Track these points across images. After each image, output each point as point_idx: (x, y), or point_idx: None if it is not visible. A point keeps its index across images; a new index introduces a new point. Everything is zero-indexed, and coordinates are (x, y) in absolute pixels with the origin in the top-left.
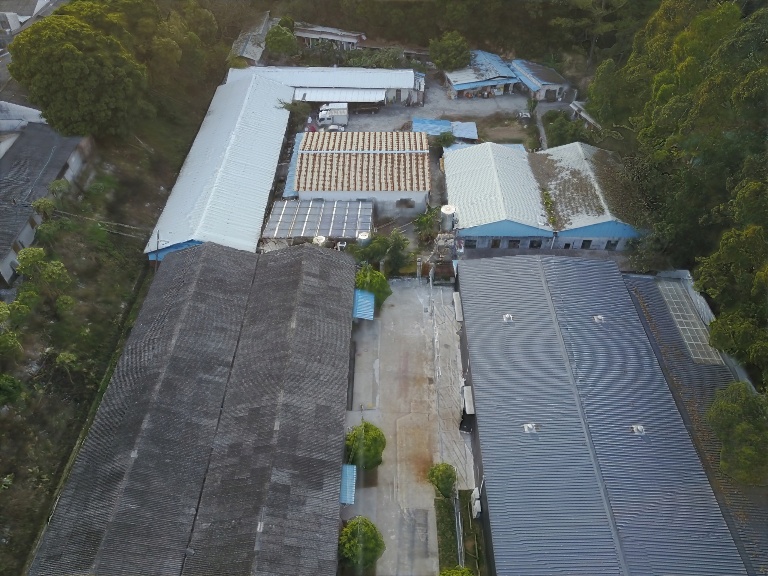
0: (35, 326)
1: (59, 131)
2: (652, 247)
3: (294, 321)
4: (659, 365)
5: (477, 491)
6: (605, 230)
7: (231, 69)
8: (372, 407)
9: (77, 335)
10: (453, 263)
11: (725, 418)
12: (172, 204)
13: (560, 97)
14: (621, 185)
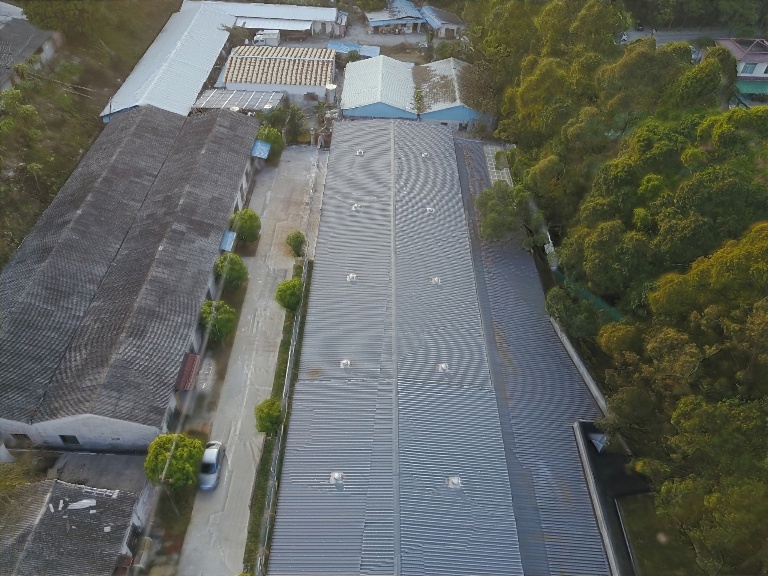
0: (12, 149)
1: (36, 24)
2: (481, 119)
3: (204, 150)
4: (459, 181)
5: None
6: (456, 114)
7: (185, 1)
8: (260, 216)
9: (44, 160)
10: None
11: (484, 198)
12: (125, 87)
13: (458, 36)
14: (477, 87)
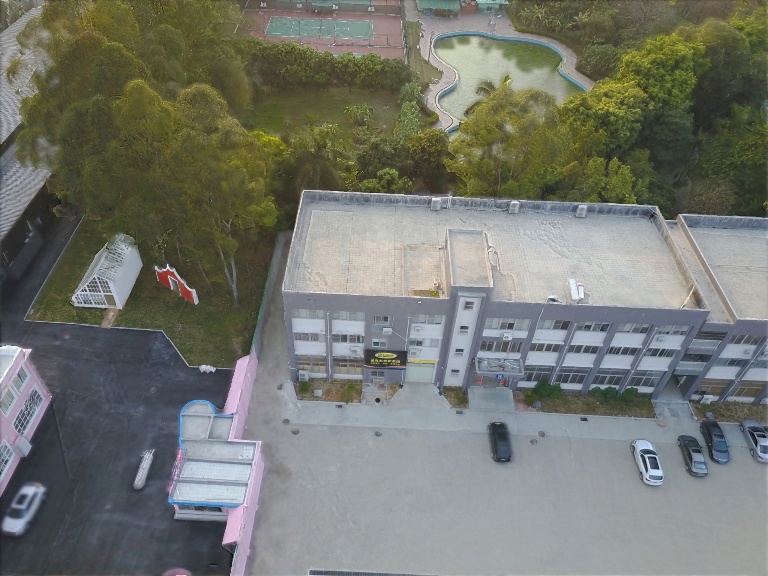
0: None
1: None
2: None
3: None
4: None
5: None
6: None
7: None
8: None
9: None
10: None
11: None
12: None
13: None
14: None
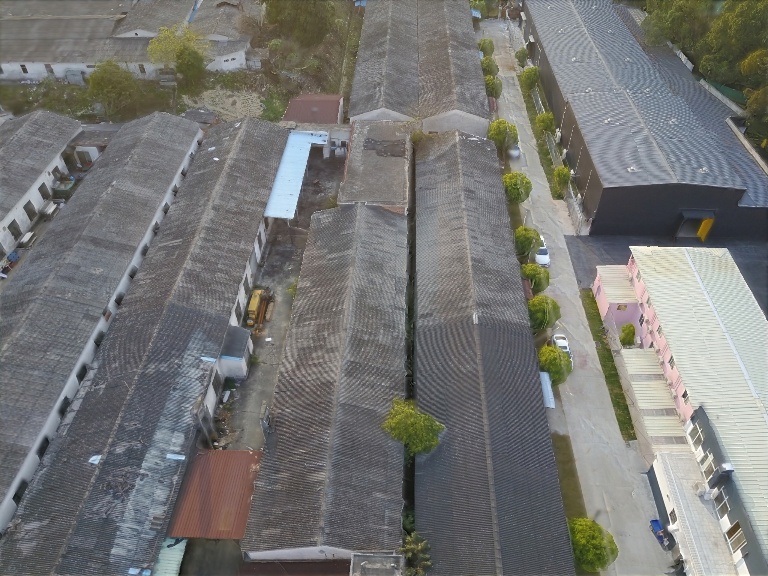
0: None
1: None
2: None
3: (446, 9)
4: (622, 20)
5: None
6: None
7: None
8: None
9: None
10: (519, 3)
11: (647, 20)
12: None
13: None
14: None
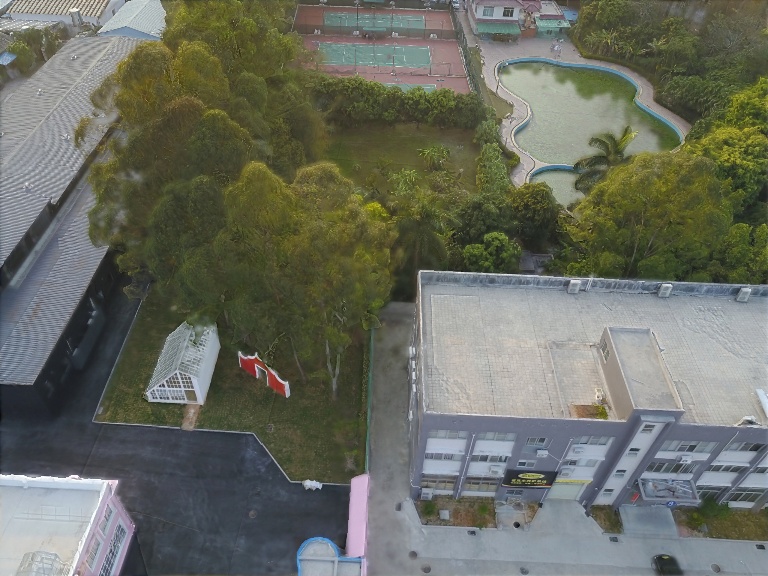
0: None
1: None
2: None
3: None
4: None
5: None
6: None
7: None
8: None
9: None
10: None
11: None
12: None
13: None
14: None
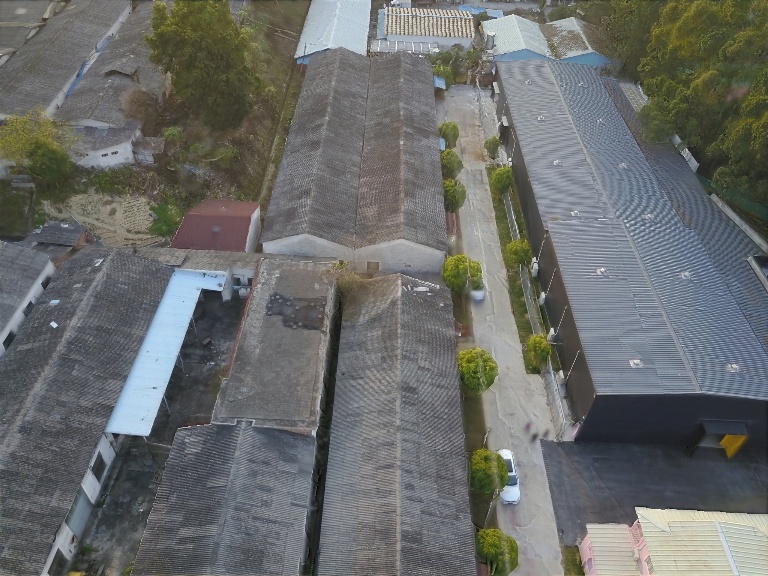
0: None
1: None
2: (616, 61)
3: (402, 79)
4: None
5: (510, 159)
6: (588, 60)
7: None
8: None
9: None
10: (492, 70)
11: (646, 111)
12: (305, 37)
13: None
14: (600, 39)
